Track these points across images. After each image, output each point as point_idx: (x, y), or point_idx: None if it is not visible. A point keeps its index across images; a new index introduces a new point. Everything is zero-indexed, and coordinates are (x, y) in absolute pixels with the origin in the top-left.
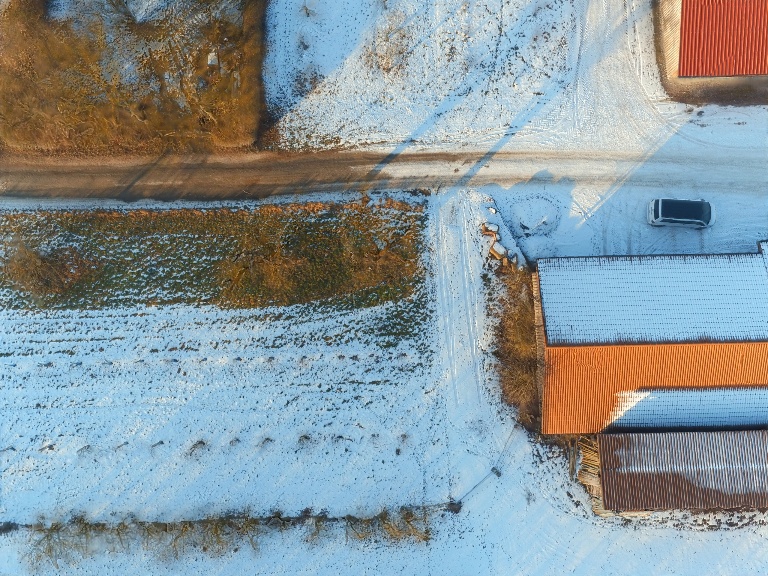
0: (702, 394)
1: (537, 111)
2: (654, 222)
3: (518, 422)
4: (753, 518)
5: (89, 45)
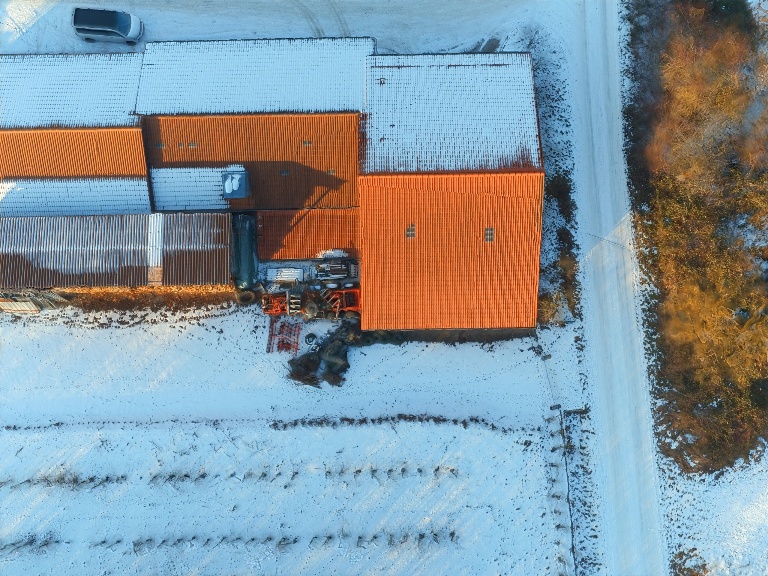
0: (68, 185)
1: None
2: (77, 34)
3: None
4: (145, 317)
5: None
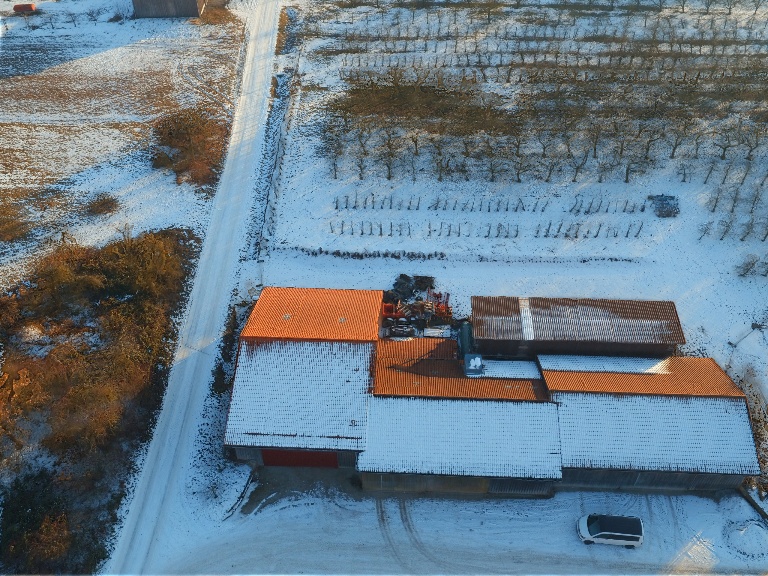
0: None
1: None
2: None
3: None
4: None
5: None
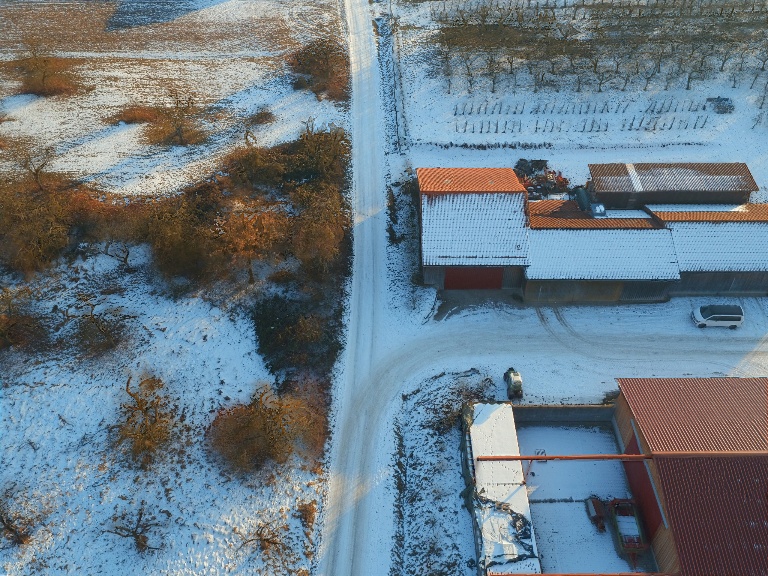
0: (699, 210)
1: None
2: None
3: None
4: None
5: None
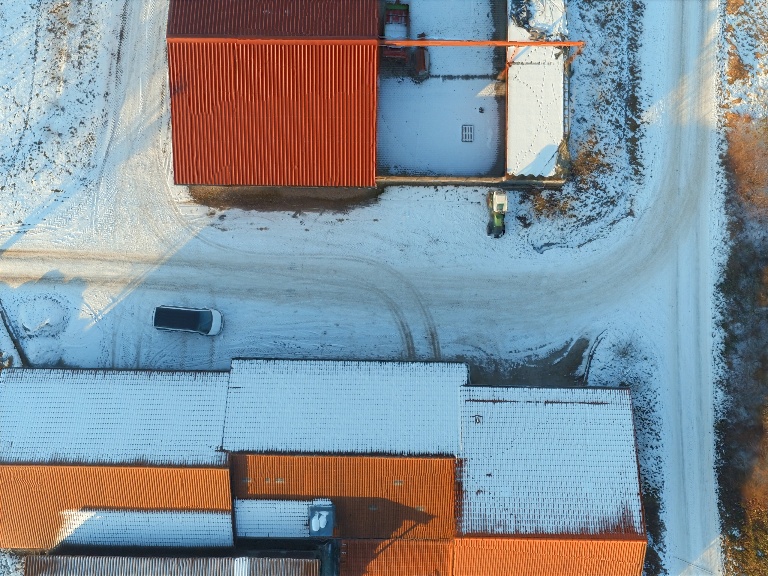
0: (149, 515)
1: (53, 209)
2: None
3: None
4: None
5: None
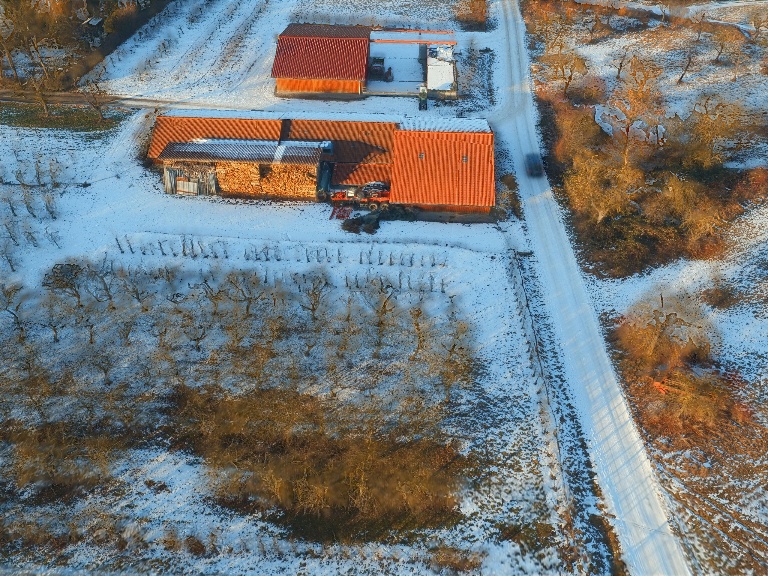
0: (235, 142)
1: (208, 94)
2: None
3: (141, 165)
4: None
5: (7, 66)
